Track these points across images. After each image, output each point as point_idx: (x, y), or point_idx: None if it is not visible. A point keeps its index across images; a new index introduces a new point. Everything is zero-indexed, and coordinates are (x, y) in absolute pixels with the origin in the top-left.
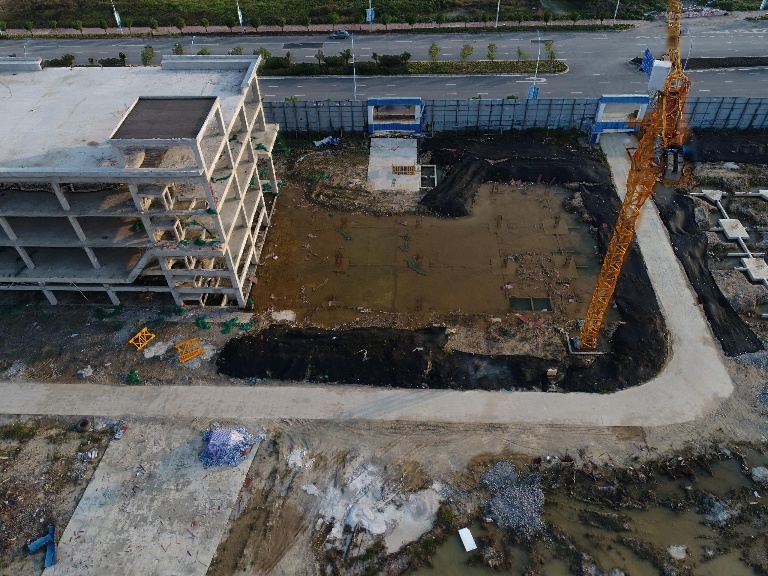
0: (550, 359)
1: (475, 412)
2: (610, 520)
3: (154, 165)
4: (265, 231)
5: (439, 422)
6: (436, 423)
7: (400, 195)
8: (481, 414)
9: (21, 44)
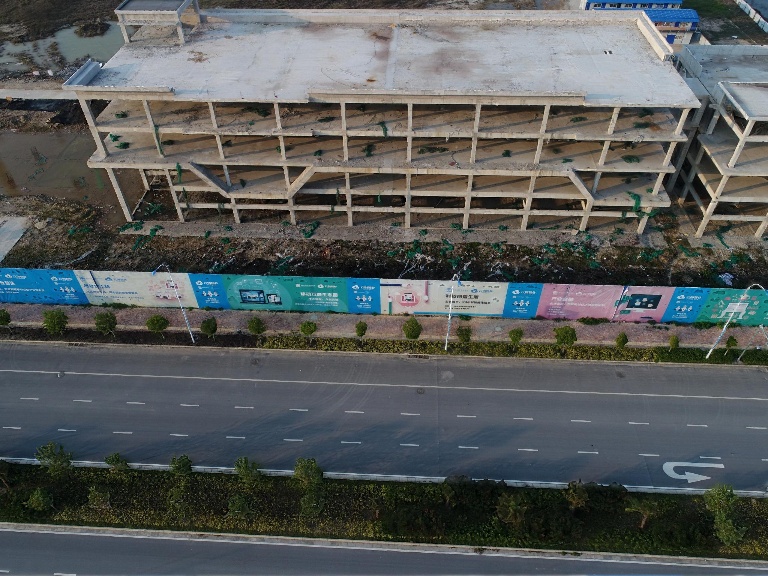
0: (3, 109)
1: (65, 93)
2: (37, 67)
3: None
4: (152, 184)
5: None
6: None
7: (6, 211)
8: (62, 92)
9: None
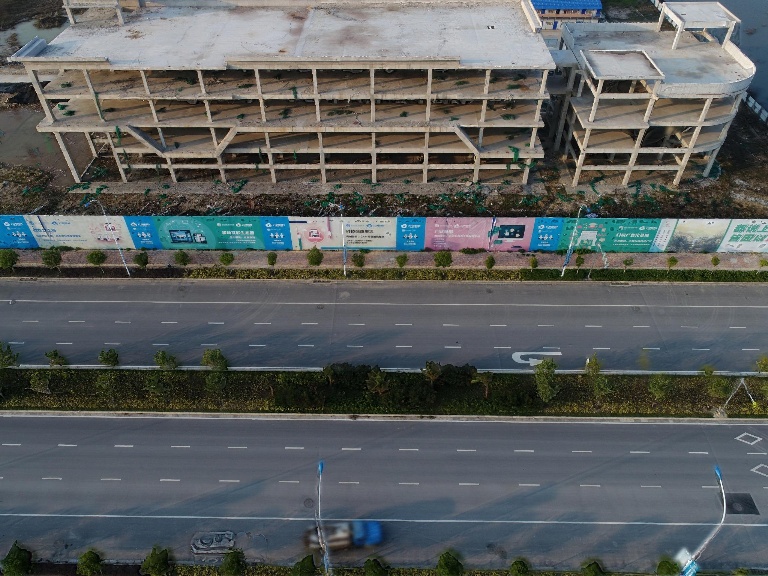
0: None
1: (23, 77)
2: None
3: (125, 17)
4: (100, 152)
5: (43, 74)
6: (44, 74)
7: None
8: None
9: (585, 540)
